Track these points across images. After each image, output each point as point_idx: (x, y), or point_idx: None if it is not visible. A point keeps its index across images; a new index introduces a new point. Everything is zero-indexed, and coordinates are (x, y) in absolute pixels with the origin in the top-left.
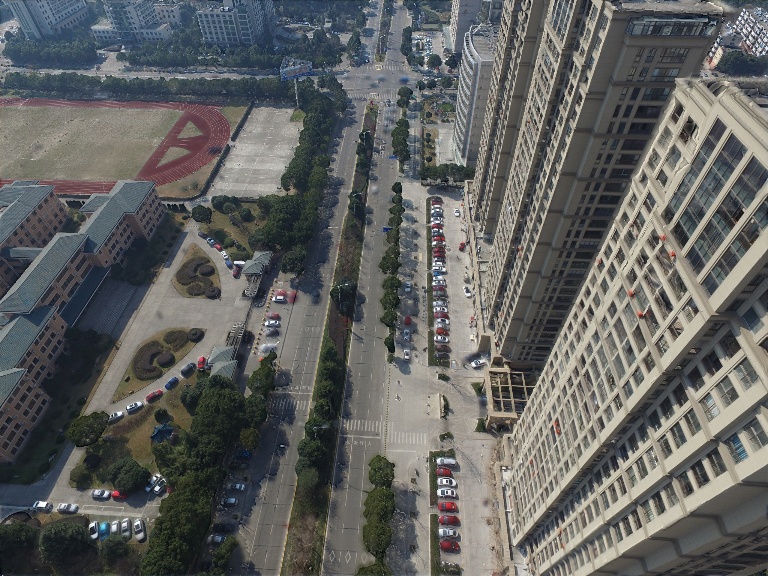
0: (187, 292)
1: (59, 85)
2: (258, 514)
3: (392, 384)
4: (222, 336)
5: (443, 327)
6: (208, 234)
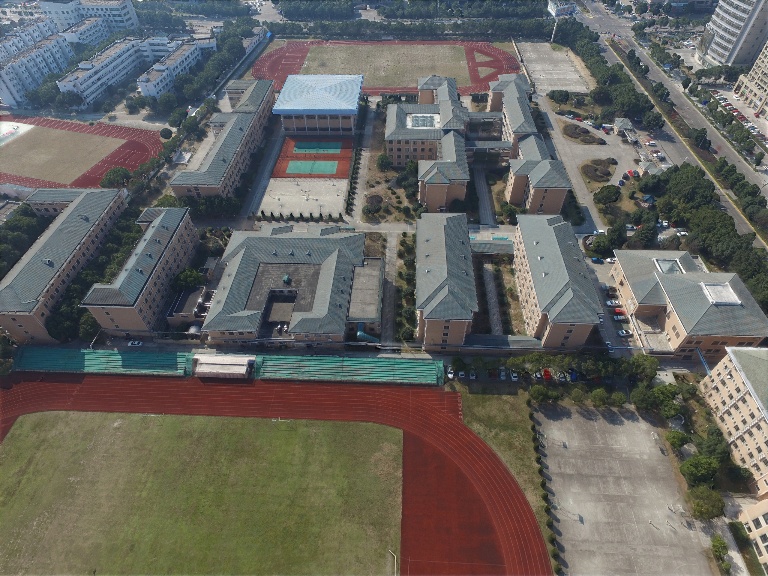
0: (582, 141)
1: (357, 29)
2: None
3: (767, 181)
4: (630, 162)
5: None
6: (563, 113)
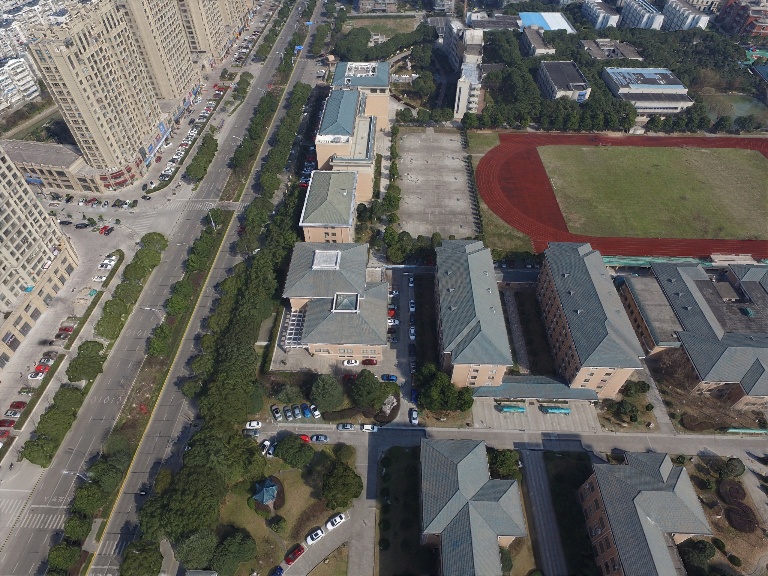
0: None
1: None
2: (176, 428)
3: None
4: None
5: None
6: None
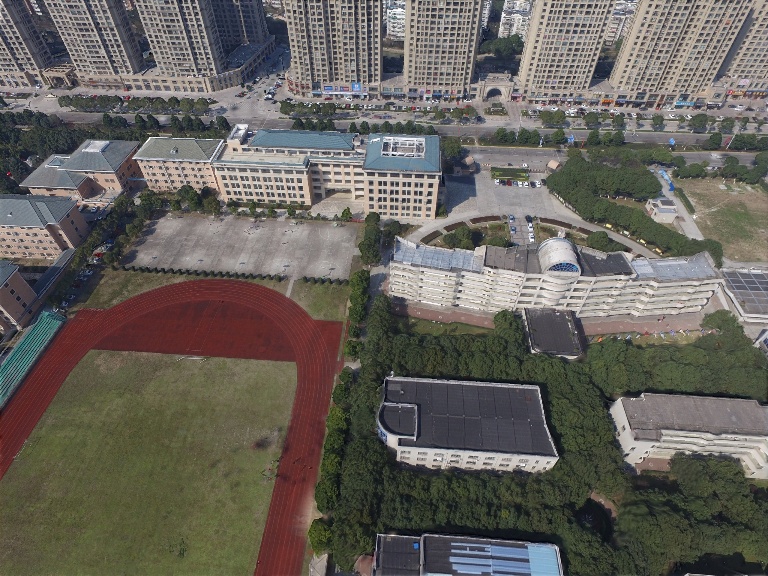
0: None
1: None
2: None
3: None
4: None
5: (7, 92)
6: None
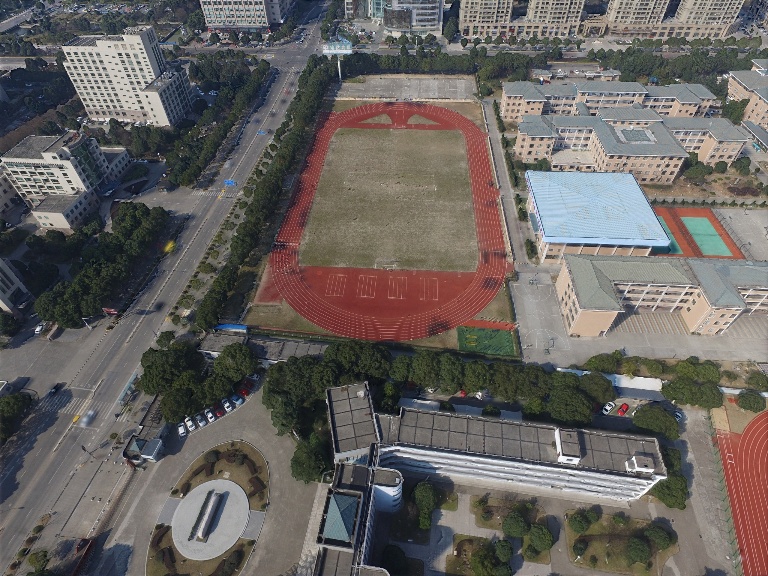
0: None
1: None
2: None
3: None
4: None
5: None
6: None
